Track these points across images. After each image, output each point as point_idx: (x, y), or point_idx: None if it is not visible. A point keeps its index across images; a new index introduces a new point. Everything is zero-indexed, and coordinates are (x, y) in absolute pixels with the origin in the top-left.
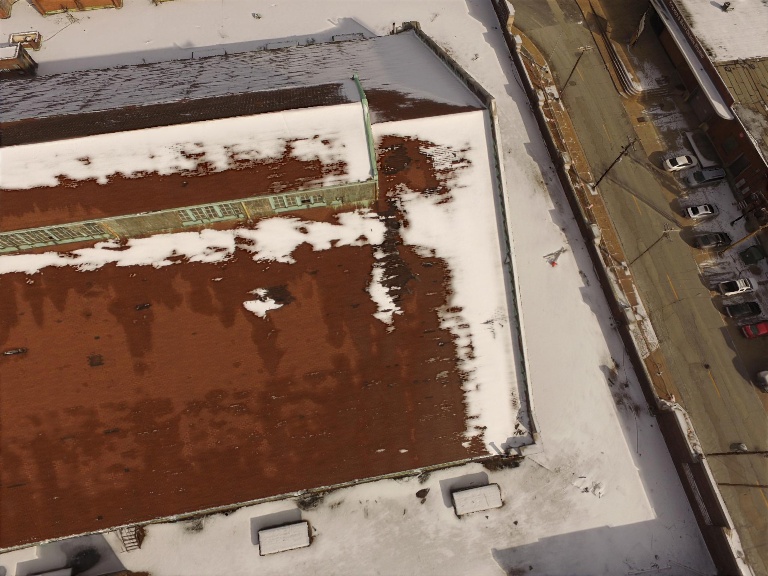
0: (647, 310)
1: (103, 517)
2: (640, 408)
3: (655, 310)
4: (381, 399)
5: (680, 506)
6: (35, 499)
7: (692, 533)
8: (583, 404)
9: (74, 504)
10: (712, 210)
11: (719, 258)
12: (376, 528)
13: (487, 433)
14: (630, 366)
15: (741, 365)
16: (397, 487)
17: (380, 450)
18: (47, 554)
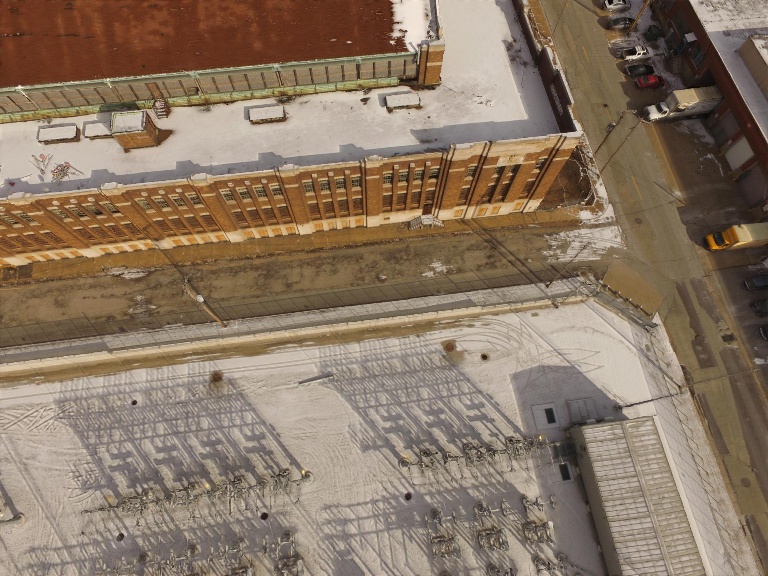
0: (564, 68)
1: (145, 66)
2: (527, 63)
3: (570, 69)
4: (335, 2)
5: (546, 114)
6: (101, 48)
7: (552, 127)
8: (486, 59)
9: (127, 55)
10: (624, 2)
11: (627, 37)
12: (331, 115)
13: (407, 35)
14: (524, 41)
15: (633, 106)
16: (347, 96)
17: (333, 40)
18: (104, 117)
